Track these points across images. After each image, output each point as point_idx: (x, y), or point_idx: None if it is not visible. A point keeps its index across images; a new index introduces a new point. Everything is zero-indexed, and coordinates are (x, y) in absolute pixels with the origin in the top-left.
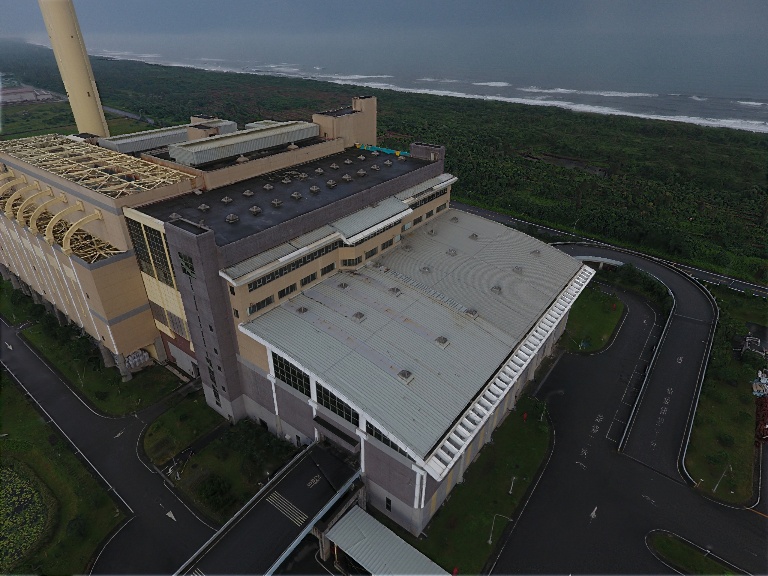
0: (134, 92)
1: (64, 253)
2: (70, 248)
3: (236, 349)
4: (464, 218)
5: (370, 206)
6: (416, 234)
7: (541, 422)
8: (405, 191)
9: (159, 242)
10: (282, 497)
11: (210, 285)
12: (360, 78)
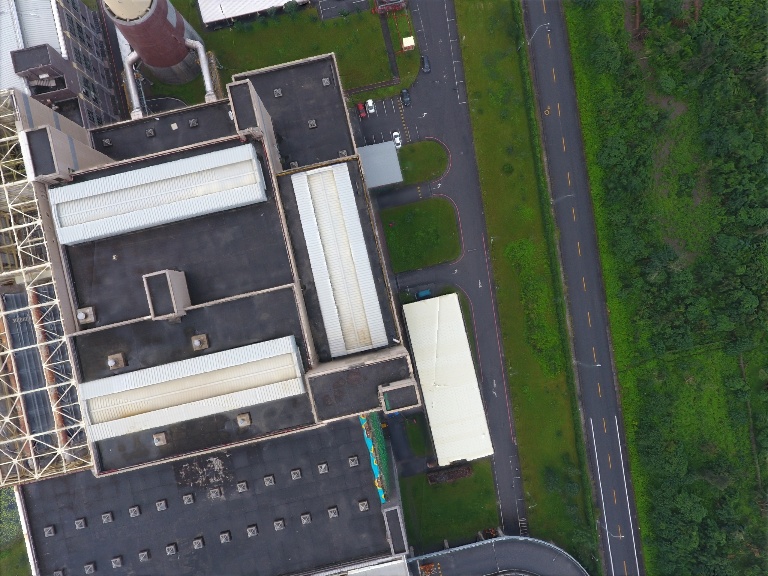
0: None
1: None
2: None
3: None
4: None
5: None
6: None
7: None
8: None
9: None
10: None
11: None
12: None
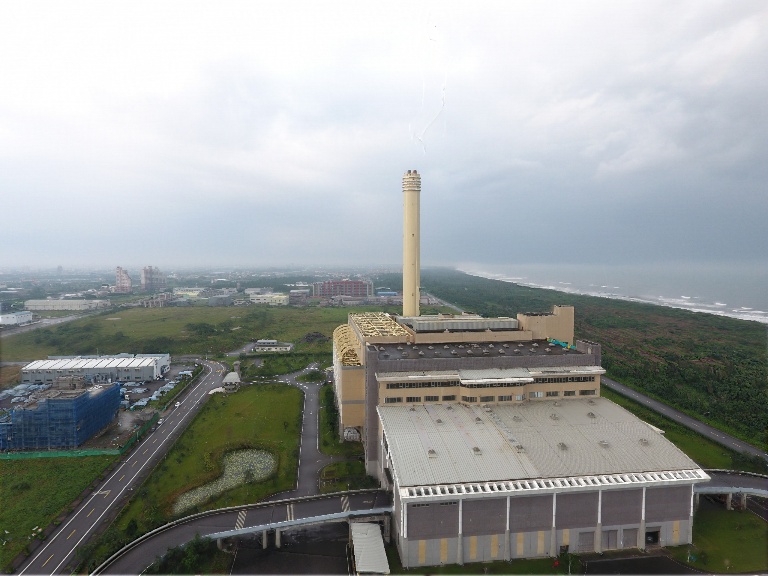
0: (497, 304)
1: None
2: (341, 359)
3: (378, 426)
4: (604, 405)
5: (499, 369)
6: (544, 402)
7: (568, 575)
8: (541, 368)
9: None
10: (348, 500)
11: (370, 379)
12: (731, 308)
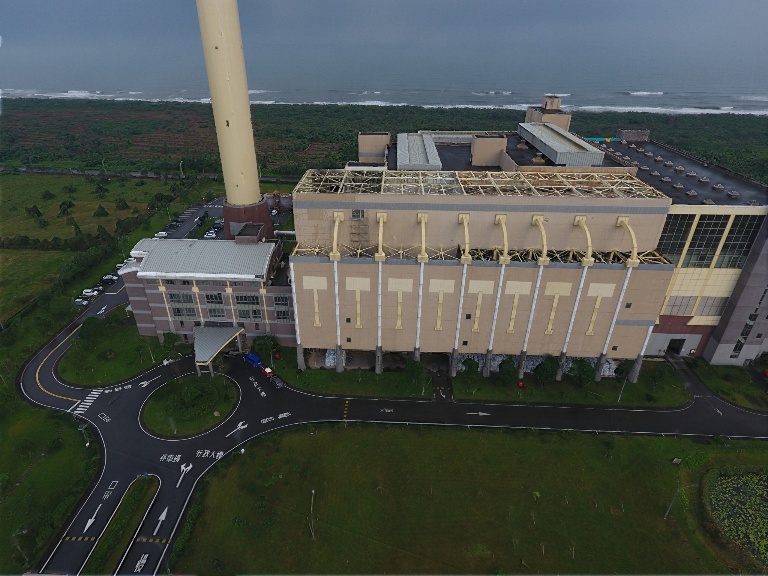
0: None
1: (631, 265)
2: None
3: None
4: None
5: None
6: None
7: None
8: None
9: (719, 226)
10: None
11: None
12: None
